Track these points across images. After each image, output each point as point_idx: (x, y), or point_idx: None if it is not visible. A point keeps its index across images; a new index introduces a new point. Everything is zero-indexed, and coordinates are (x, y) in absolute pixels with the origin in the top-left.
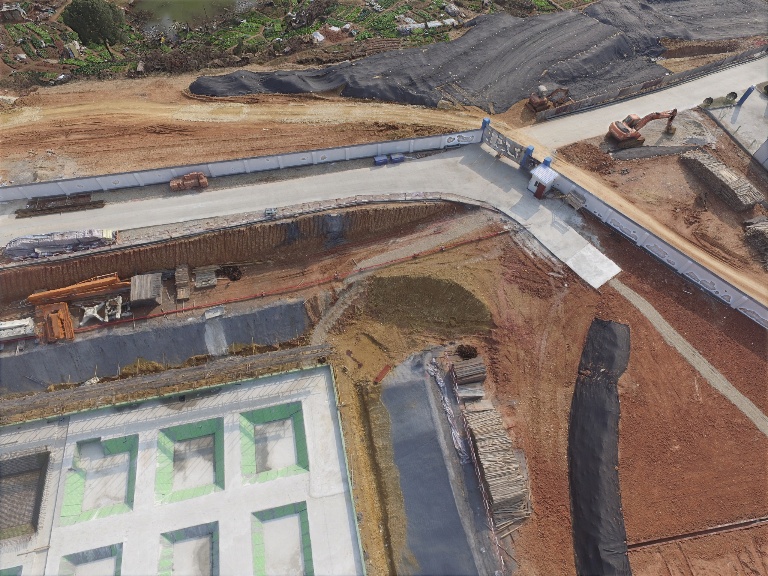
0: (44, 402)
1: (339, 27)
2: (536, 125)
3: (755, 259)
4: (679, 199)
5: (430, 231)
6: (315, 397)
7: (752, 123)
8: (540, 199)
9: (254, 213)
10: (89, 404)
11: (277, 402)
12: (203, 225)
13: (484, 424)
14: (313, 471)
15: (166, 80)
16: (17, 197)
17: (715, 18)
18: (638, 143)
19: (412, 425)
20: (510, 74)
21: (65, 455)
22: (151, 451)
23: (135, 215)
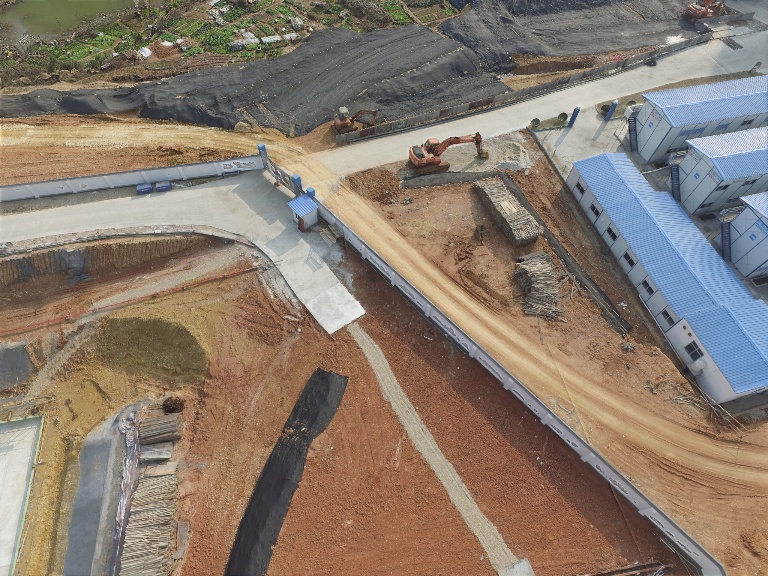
0: None
1: (172, 42)
2: (335, 149)
3: (516, 300)
4: (457, 232)
5: (180, 267)
6: (16, 453)
7: (577, 146)
8: (303, 232)
9: None
10: None
11: None
12: None
13: (151, 493)
14: None
15: None
16: None
17: (579, 32)
18: (442, 168)
19: (89, 490)
20: (326, 93)
21: None
22: None
23: None
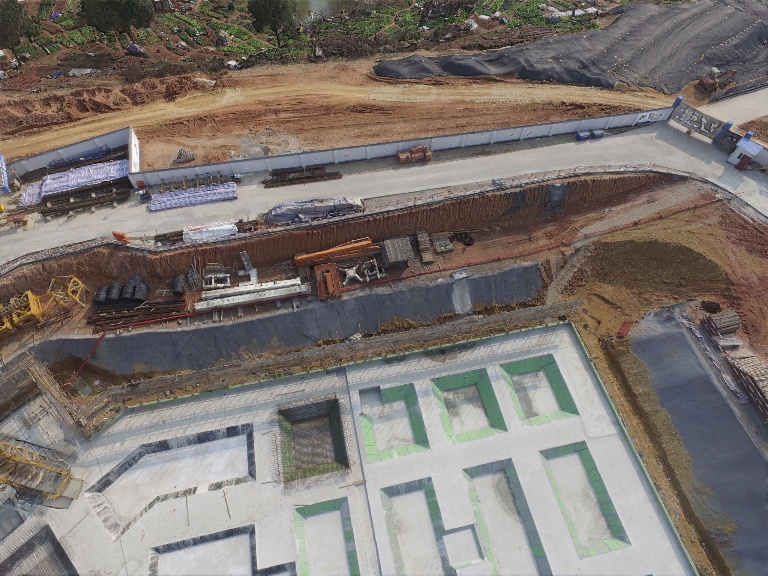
0: (331, 353)
1: (488, 15)
2: (711, 105)
3: None
4: None
5: (643, 200)
6: (564, 351)
7: None
8: (742, 171)
9: (483, 183)
10: (361, 357)
11: (531, 355)
12: (439, 194)
13: (755, 368)
14: (583, 415)
15: (346, 64)
16: (259, 169)
17: None
18: None
19: (677, 372)
20: (671, 58)
21: (352, 402)
22: (430, 398)
23: (374, 185)
